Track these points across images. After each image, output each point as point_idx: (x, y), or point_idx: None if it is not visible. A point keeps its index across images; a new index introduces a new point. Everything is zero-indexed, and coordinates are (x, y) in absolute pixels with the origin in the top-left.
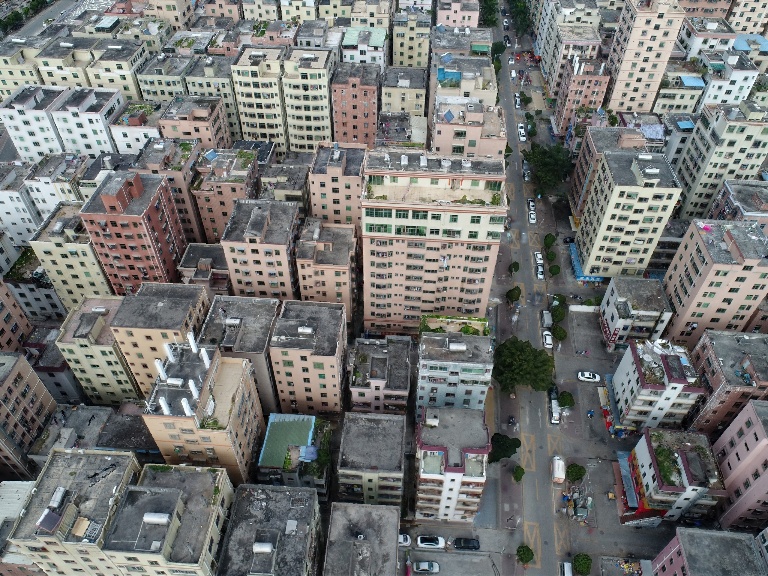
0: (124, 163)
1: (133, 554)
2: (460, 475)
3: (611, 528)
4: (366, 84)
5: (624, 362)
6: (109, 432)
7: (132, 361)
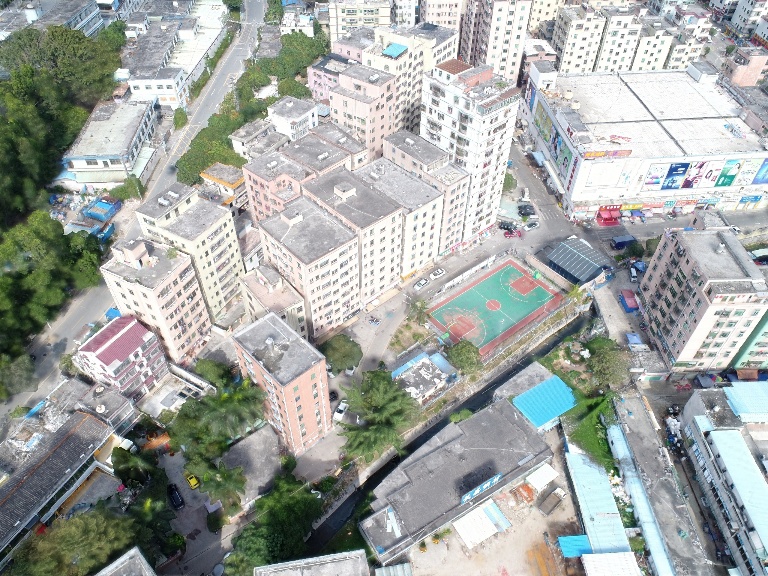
0: None
1: (623, 17)
2: None
3: None
4: None
5: (739, 5)
6: (550, 24)
7: (535, 8)
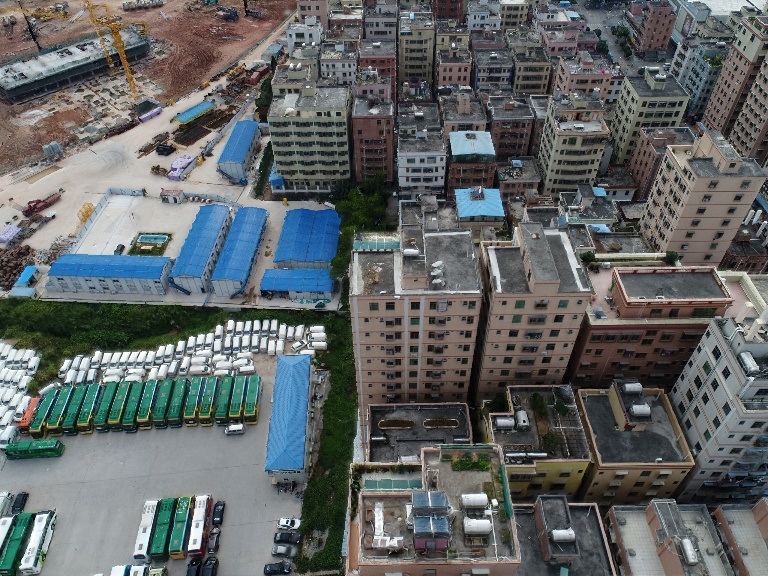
0: None
1: None
2: None
3: None
4: None
5: None
6: None
7: None
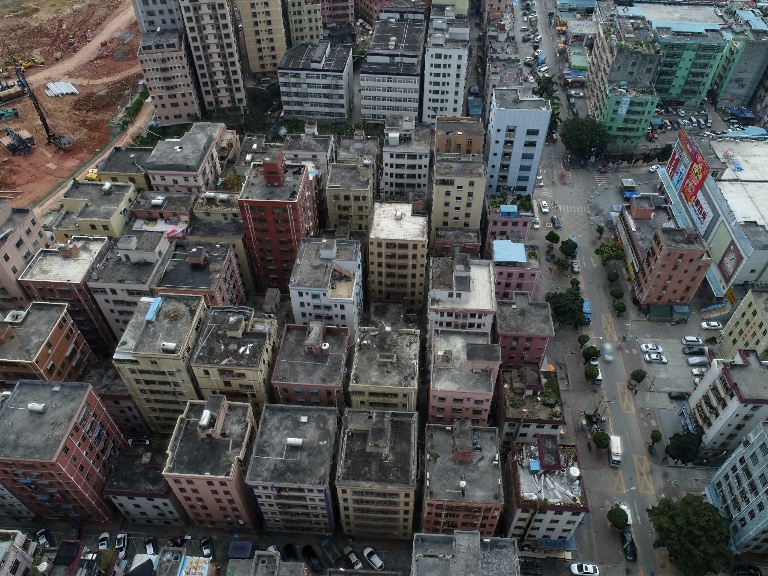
0: None
1: None
2: None
3: None
4: None
5: None
6: None
7: None
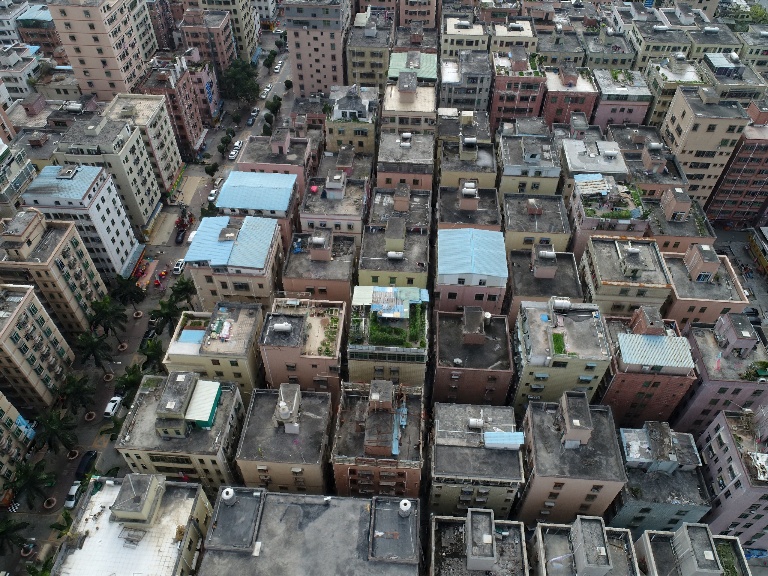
0: (572, 8)
1: None
2: None
3: None
4: (406, 34)
5: None
6: None
7: None
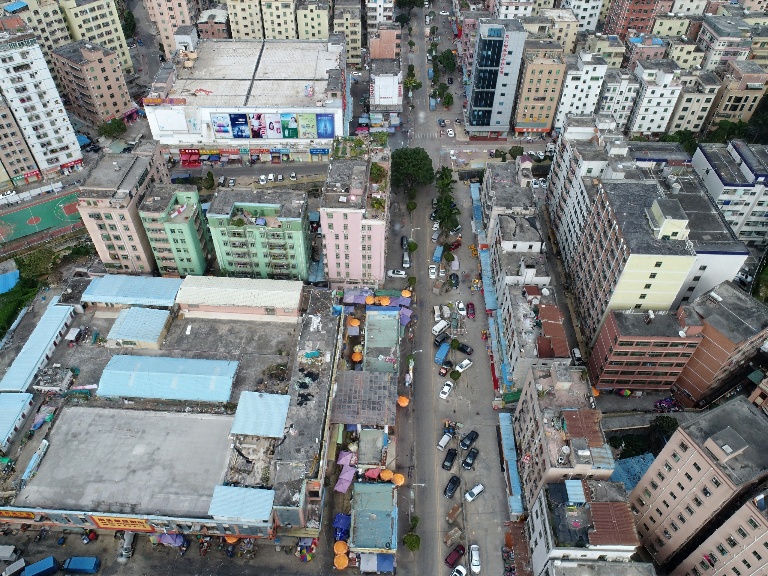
0: None
1: None
2: (382, 1)
3: (448, 45)
4: None
5: None
6: None
7: None
